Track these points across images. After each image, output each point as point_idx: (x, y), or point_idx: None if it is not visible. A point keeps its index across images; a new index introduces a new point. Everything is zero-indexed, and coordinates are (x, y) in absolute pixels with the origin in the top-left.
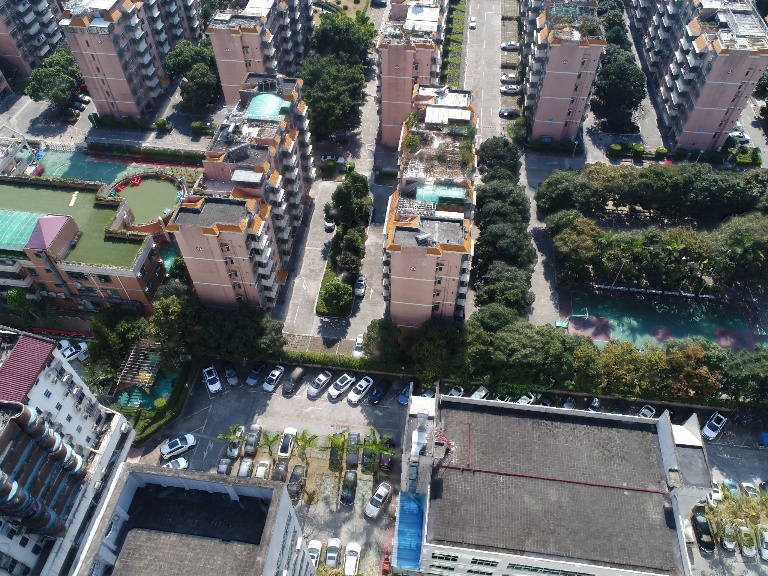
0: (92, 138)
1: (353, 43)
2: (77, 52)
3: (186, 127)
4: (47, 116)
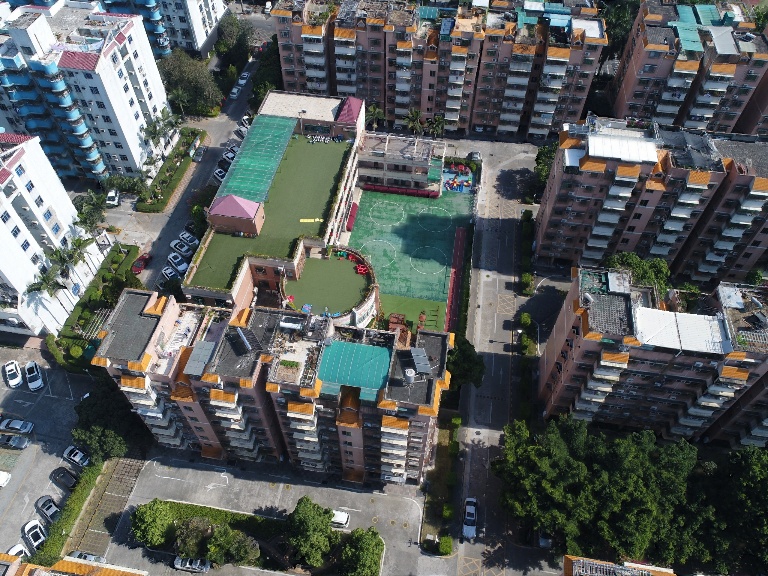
0: (499, 224)
1: (758, 534)
2: (555, 159)
3: (534, 310)
4: (535, 178)
